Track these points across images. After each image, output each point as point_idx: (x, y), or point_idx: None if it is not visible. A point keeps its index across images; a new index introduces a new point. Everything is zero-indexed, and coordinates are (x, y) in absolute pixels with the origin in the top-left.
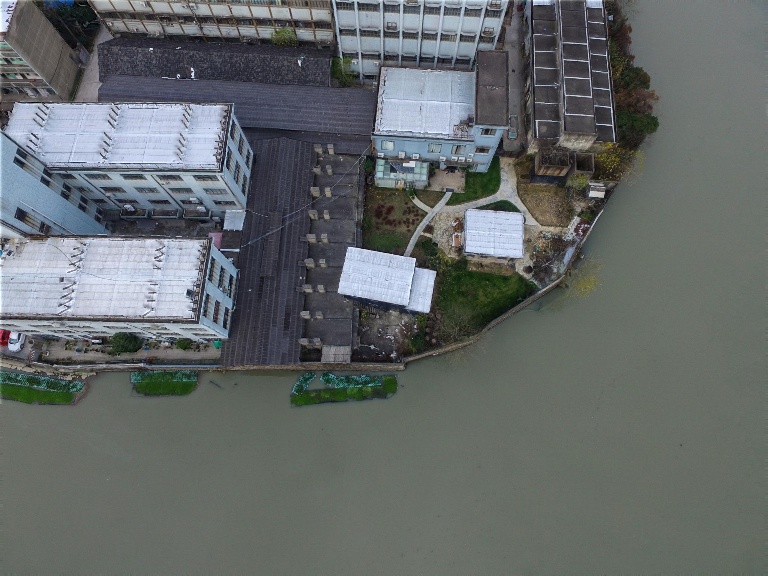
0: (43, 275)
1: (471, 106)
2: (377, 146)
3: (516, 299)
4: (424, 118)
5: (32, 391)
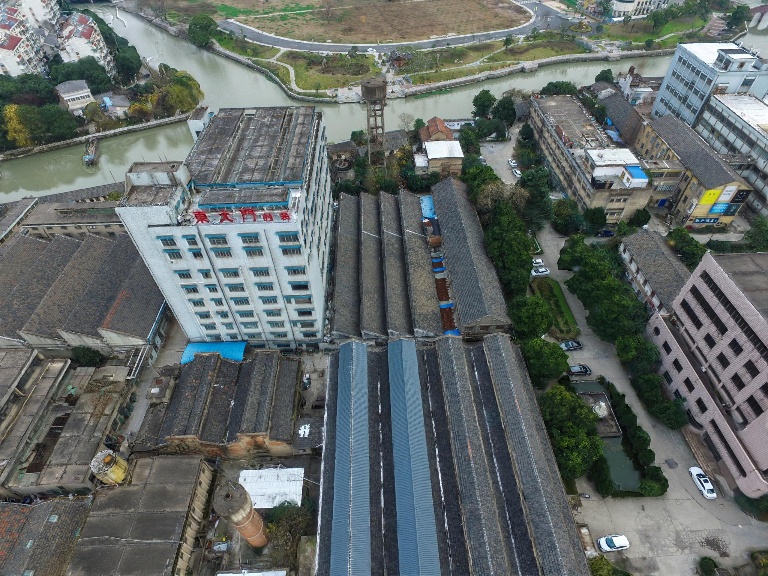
0: None
1: None
2: None
3: None
4: (767, 100)
5: None
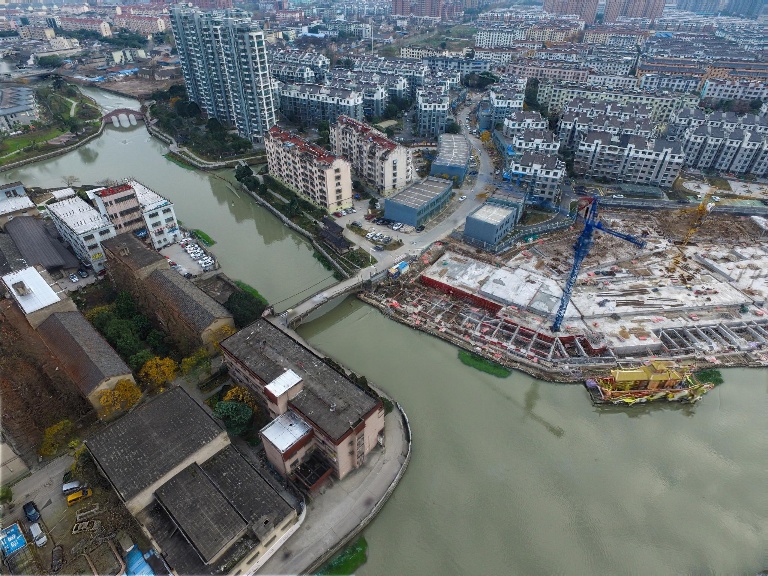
0: (143, 198)
1: (8, 198)
2: (39, 213)
3: (87, 190)
4: (20, 202)
5: (203, 236)
